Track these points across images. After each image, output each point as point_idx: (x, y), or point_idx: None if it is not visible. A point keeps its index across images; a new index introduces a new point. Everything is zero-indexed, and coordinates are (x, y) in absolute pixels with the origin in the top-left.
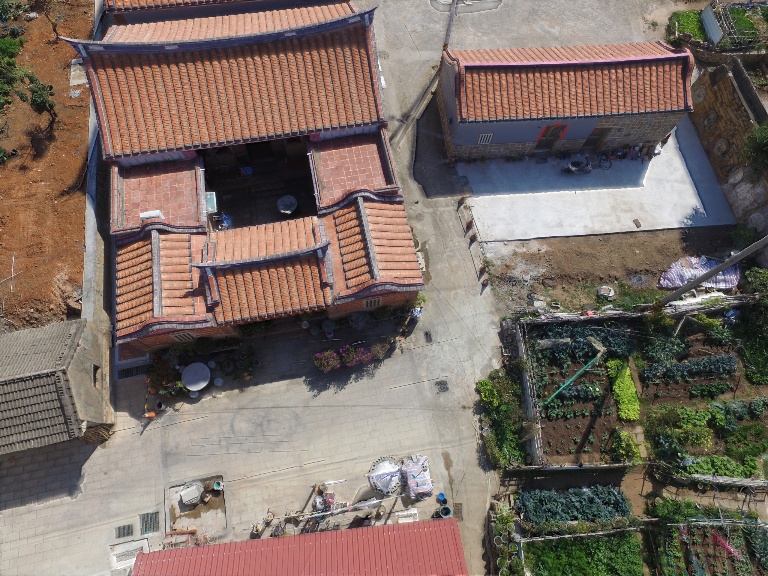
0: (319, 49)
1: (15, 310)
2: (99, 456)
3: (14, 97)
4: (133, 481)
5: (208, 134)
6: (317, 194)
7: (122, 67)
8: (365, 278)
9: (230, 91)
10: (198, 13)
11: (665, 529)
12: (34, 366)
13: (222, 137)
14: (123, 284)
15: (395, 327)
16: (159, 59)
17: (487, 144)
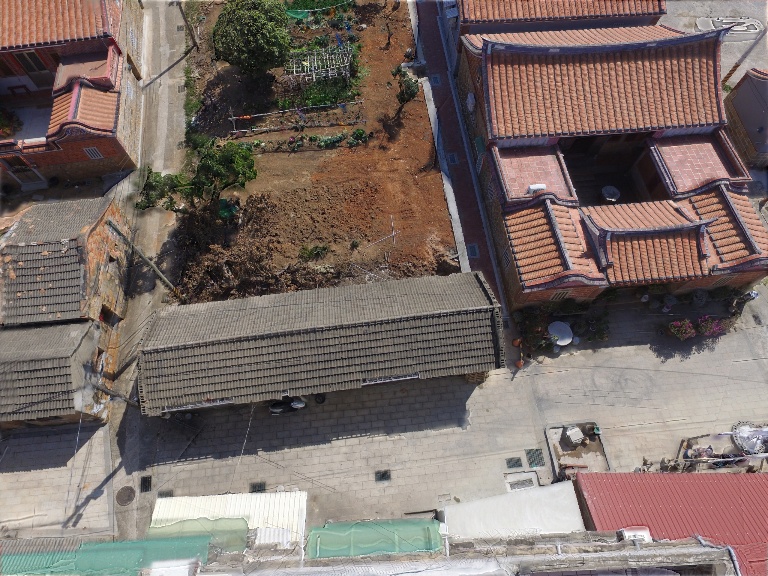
0: (672, 59)
1: (397, 263)
2: (479, 395)
3: (361, 90)
4: (513, 420)
5: (575, 124)
6: (670, 181)
7: (511, 64)
8: (742, 253)
9: (594, 90)
10: (529, 28)
11: None
12: (469, 303)
13: (587, 128)
14: (519, 243)
15: (724, 308)
16: (540, 60)
17: None
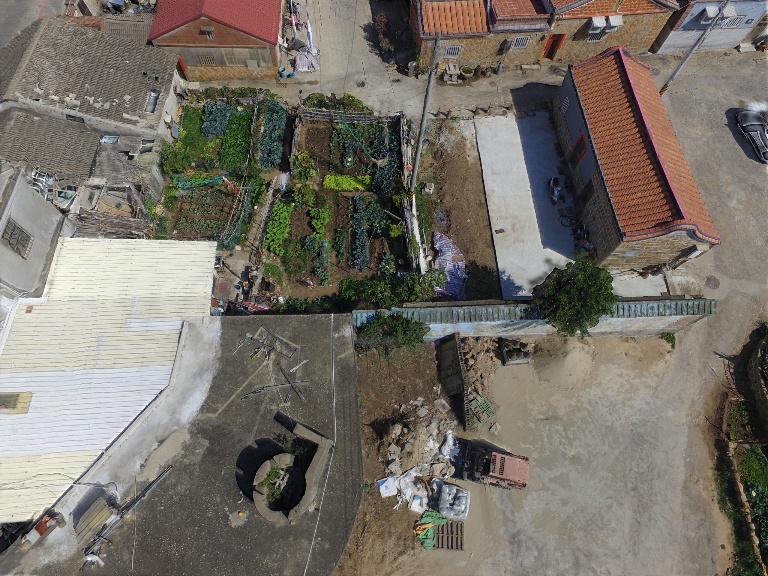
0: None
1: None
2: None
3: None
4: None
5: None
6: None
7: None
8: None
9: None
10: None
11: None
12: None
13: None
14: None
15: (404, 64)
16: None
17: None
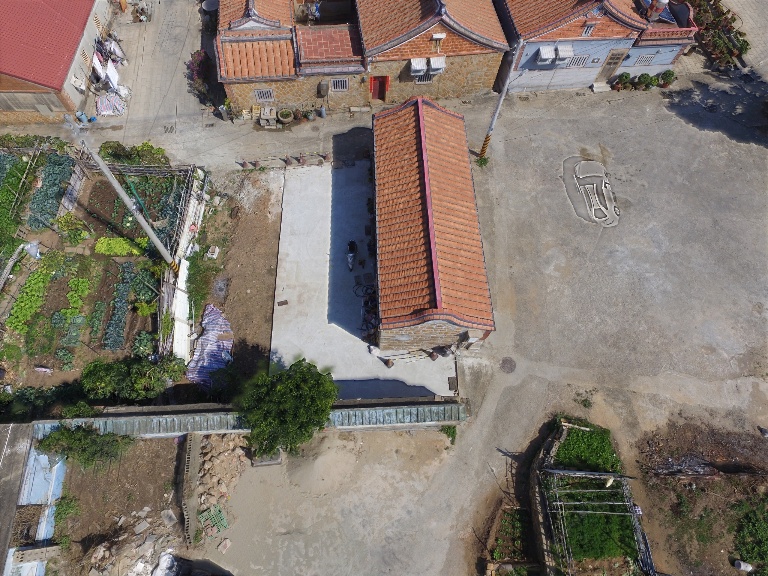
0: None
1: None
2: None
3: None
4: None
5: None
6: None
7: None
8: None
9: None
10: None
11: None
12: None
13: None
14: None
15: None
16: None
17: None
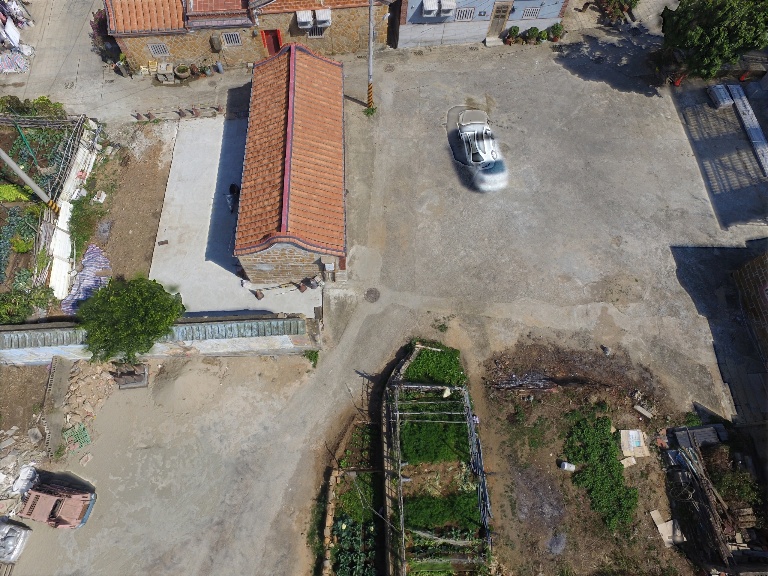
0: None
1: None
2: None
3: None
4: None
5: None
6: None
7: None
8: None
9: None
10: None
11: None
12: None
13: None
14: None
15: None
16: None
17: None
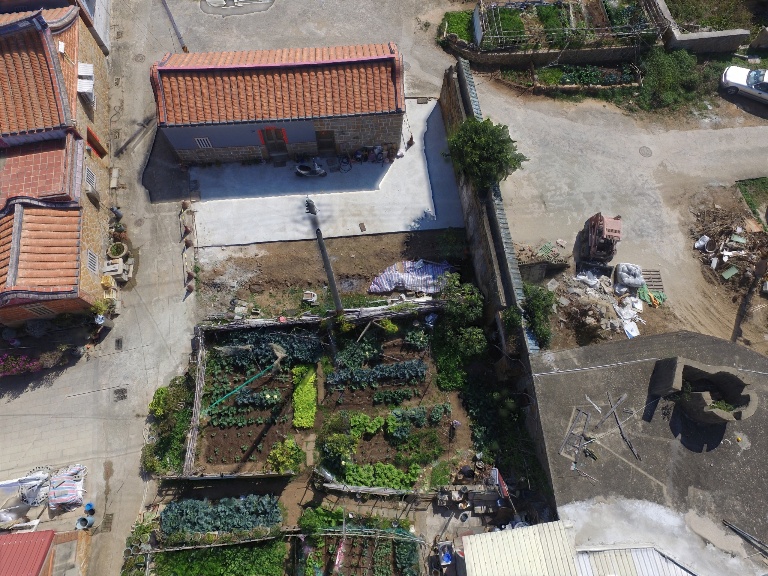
0: None
1: None
2: None
3: None
4: None
5: None
6: None
7: None
8: (3, 286)
9: None
10: None
11: (311, 539)
12: None
13: None
14: None
15: None
16: None
17: (211, 148)
